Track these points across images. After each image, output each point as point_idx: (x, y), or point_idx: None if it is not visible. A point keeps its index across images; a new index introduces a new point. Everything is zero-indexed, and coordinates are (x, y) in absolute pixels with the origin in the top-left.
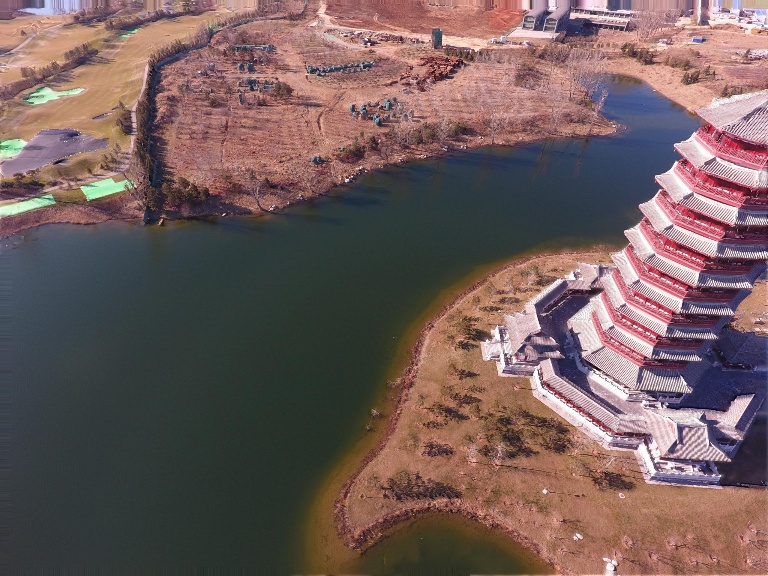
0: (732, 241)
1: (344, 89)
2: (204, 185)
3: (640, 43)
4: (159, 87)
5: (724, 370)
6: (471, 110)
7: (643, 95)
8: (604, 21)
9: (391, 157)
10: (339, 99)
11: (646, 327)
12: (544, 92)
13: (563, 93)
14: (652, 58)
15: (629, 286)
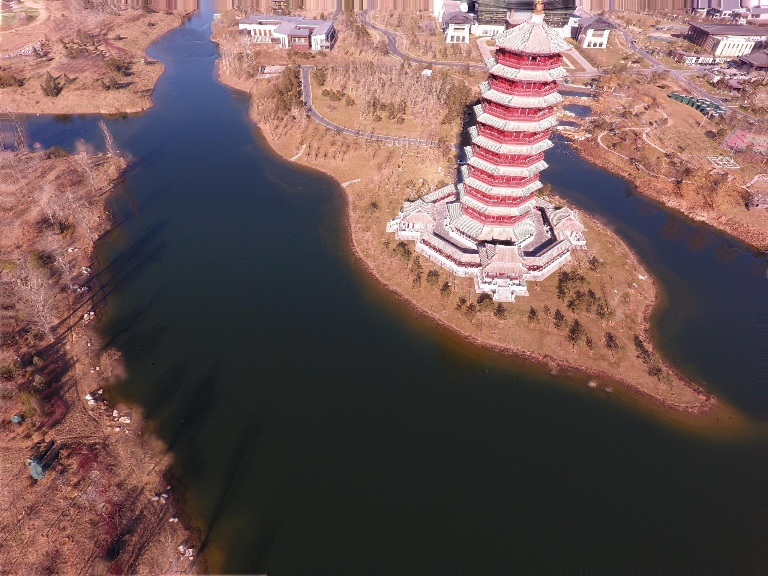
0: None
1: None
2: None
3: None
4: None
5: None
6: None
7: (43, 123)
8: None
9: (71, 353)
10: None
11: None
12: None
13: None
14: None
15: None
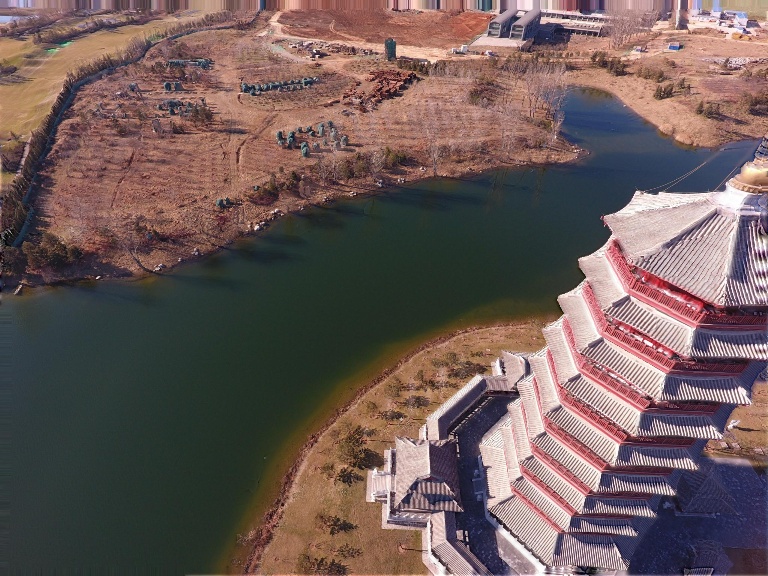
0: (661, 411)
1: (277, 111)
2: (80, 240)
3: (611, 52)
4: (68, 112)
5: (678, 515)
6: (415, 135)
7: (612, 112)
8: (576, 26)
9: (314, 196)
10: (268, 124)
11: (558, 494)
12: (500, 111)
13: (523, 111)
14: (624, 68)
15: (532, 440)
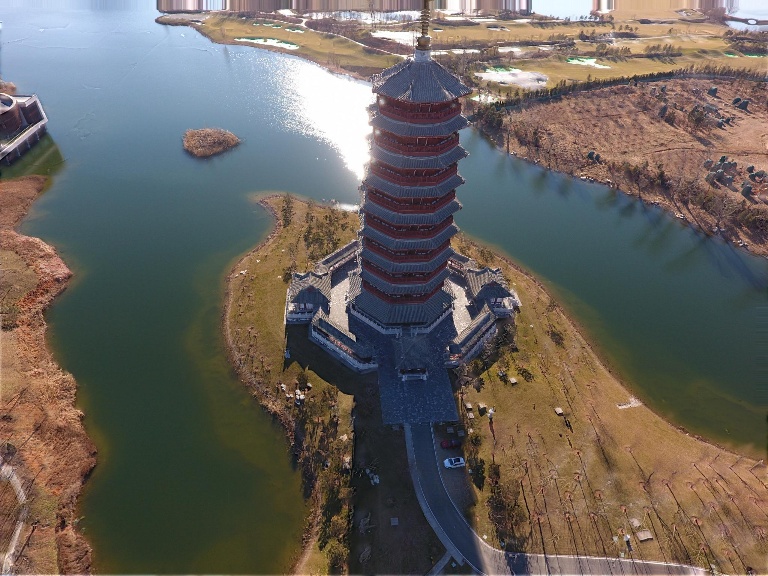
0: None
1: None
2: (514, 123)
3: None
4: None
5: None
6: None
7: None
8: None
9: (653, 196)
10: (740, 153)
11: None
12: None
13: None
14: None
15: None
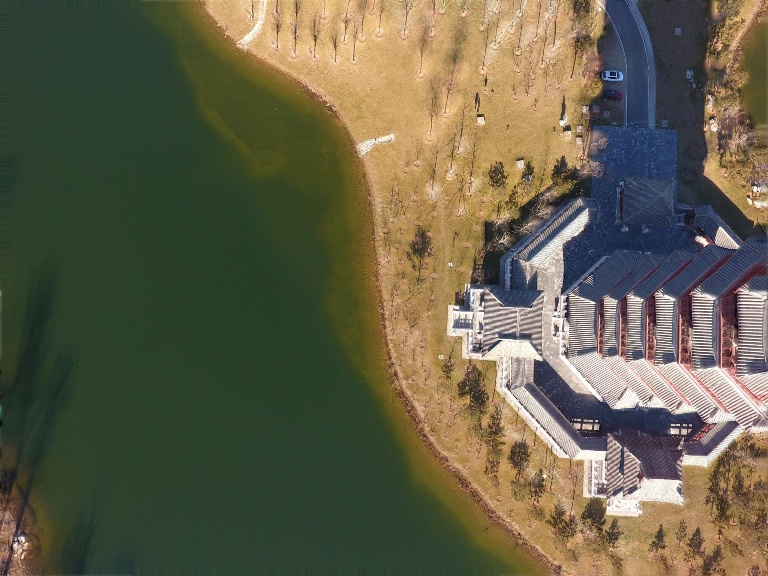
0: None
1: None
2: None
3: None
4: None
5: None
6: None
7: None
8: None
9: None
10: None
11: None
12: None
13: None
14: None
15: None
